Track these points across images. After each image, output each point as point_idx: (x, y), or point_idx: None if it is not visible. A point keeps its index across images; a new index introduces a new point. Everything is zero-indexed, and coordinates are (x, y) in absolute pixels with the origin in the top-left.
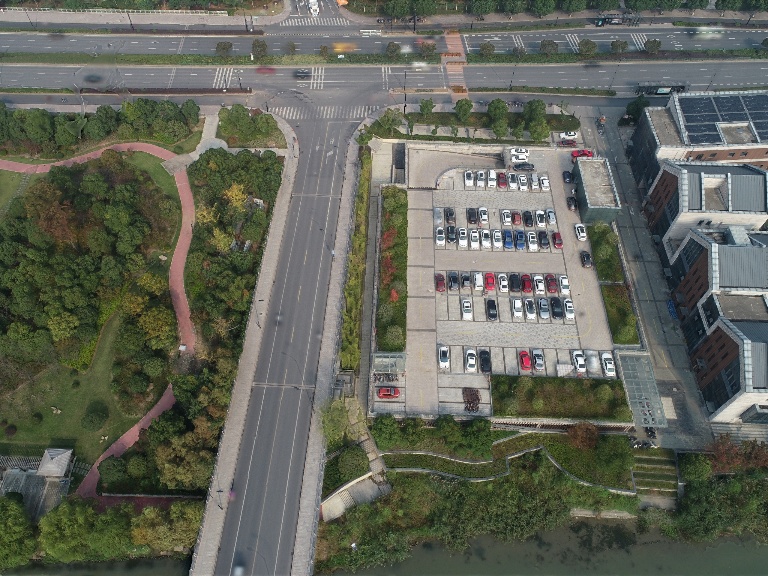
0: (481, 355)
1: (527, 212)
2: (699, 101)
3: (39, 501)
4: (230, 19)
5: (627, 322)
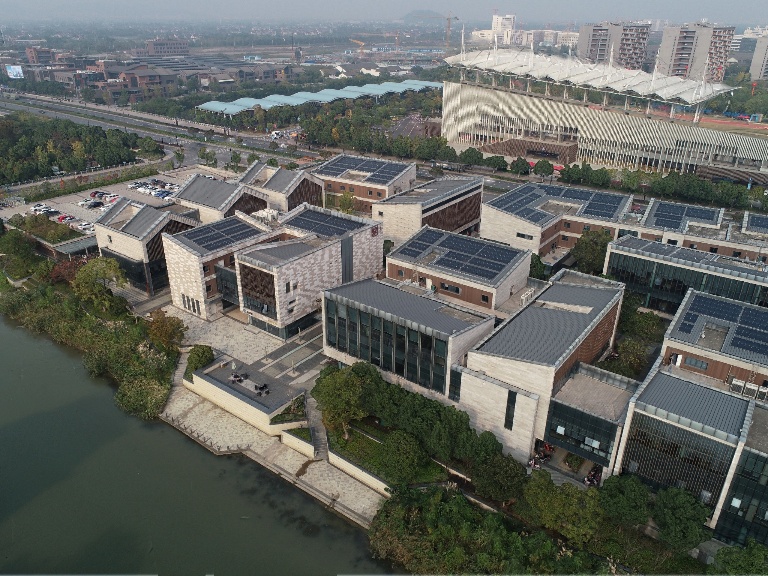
0: None
1: None
2: (356, 160)
3: None
4: (229, 132)
5: None
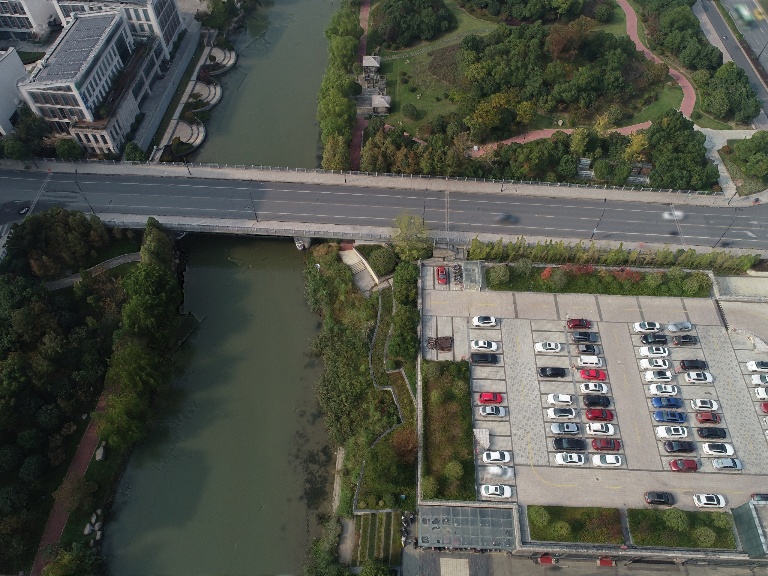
0: (491, 354)
1: (723, 431)
2: None
3: (360, 106)
4: None
5: (558, 522)
